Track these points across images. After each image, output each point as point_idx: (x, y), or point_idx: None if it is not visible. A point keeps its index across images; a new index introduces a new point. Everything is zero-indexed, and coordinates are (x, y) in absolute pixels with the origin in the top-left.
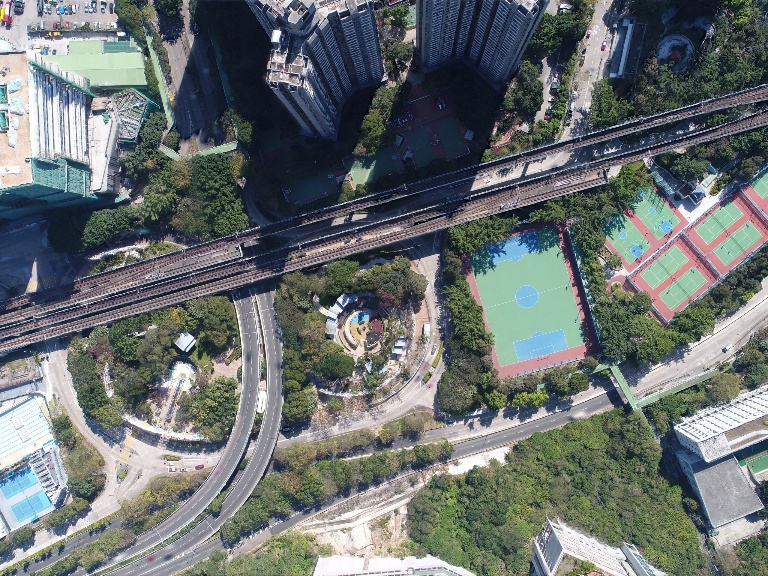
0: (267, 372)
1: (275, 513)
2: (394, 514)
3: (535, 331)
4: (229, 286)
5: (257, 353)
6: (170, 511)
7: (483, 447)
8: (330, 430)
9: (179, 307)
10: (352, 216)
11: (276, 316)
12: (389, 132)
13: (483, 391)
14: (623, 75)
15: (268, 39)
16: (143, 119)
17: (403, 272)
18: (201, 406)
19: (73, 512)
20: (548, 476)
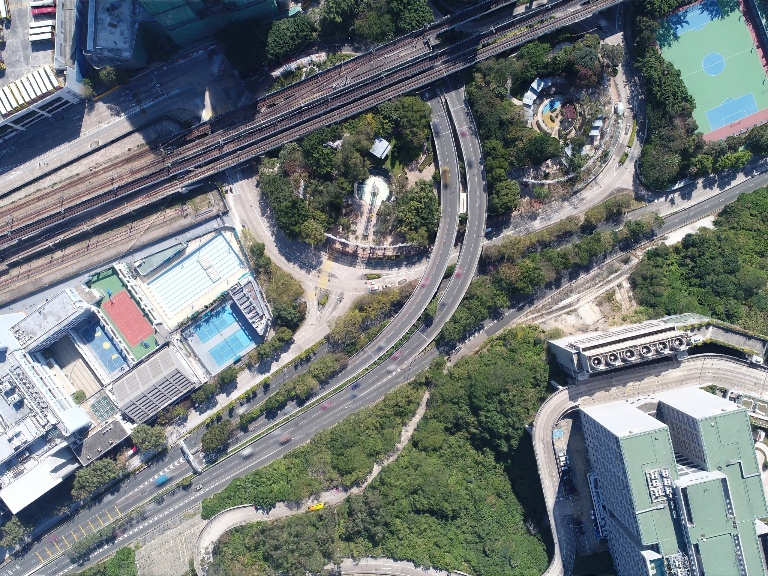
0: (466, 170)
1: (489, 313)
2: (618, 288)
3: (725, 98)
4: (421, 83)
5: (453, 153)
6: (381, 327)
7: (687, 220)
8: (531, 225)
9: (370, 113)
10: (532, 3)
11: (474, 107)
12: None
13: (687, 159)
14: None
15: None
16: None
17: (595, 49)
18: (407, 209)
19: (279, 343)
20: (766, 228)
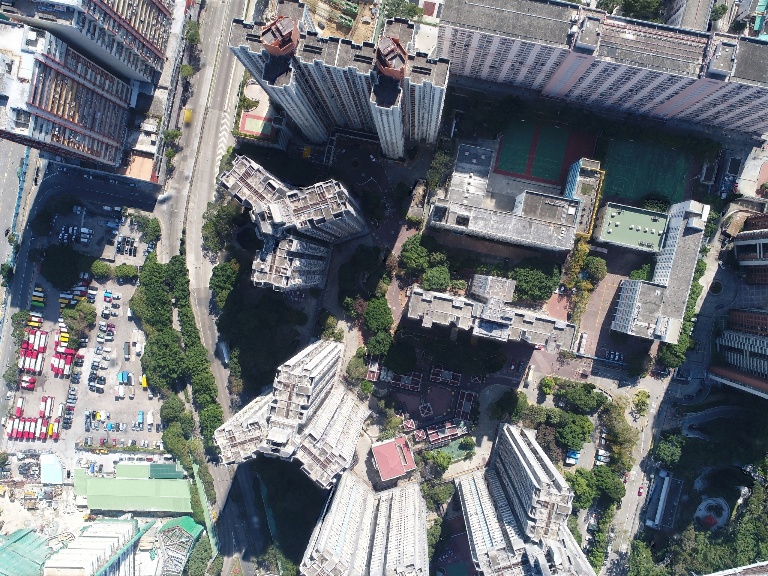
0: None
1: None
2: None
3: None
4: None
5: None
6: None
7: None
8: None
9: None
10: None
11: None
12: (430, 574)
13: None
14: (659, 527)
15: (313, 484)
16: (189, 554)
17: None
18: None
19: None
20: None
